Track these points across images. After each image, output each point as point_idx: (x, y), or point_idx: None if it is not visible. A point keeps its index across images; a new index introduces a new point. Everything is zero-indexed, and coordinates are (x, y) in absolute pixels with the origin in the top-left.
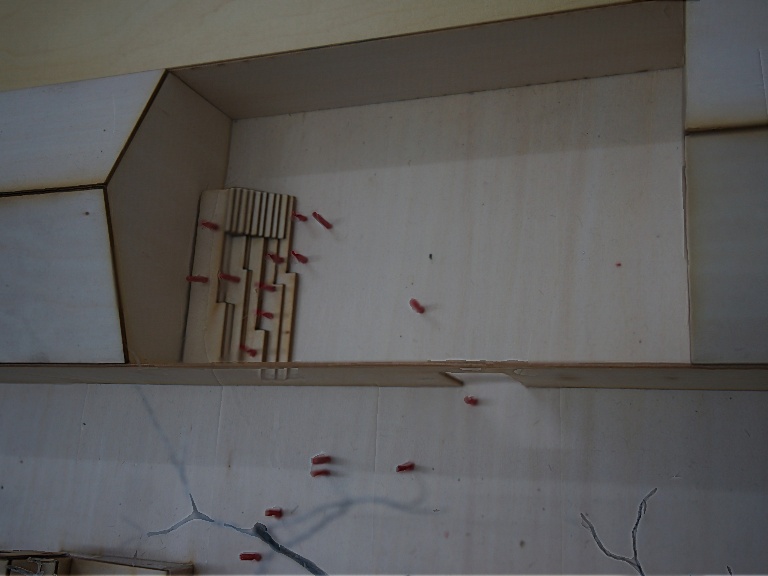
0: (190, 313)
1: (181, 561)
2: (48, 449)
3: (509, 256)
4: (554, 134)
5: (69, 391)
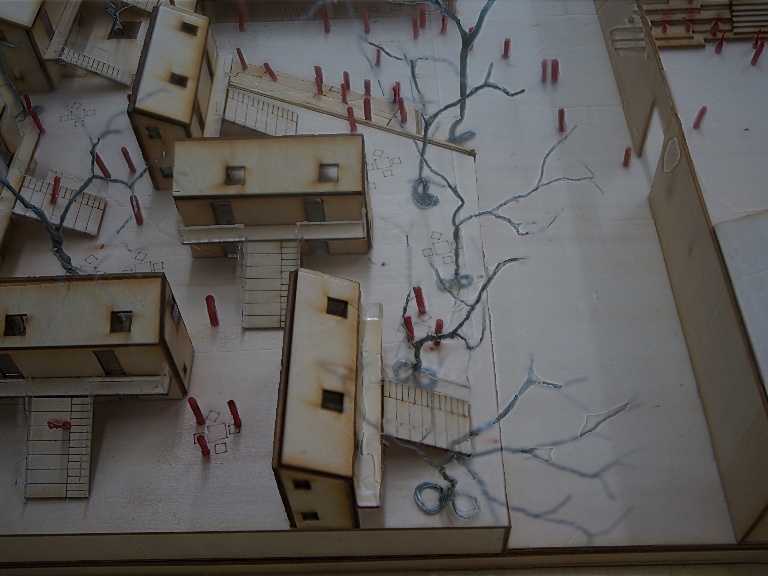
0: None
1: (457, 7)
2: None
3: (764, 179)
4: None
5: None
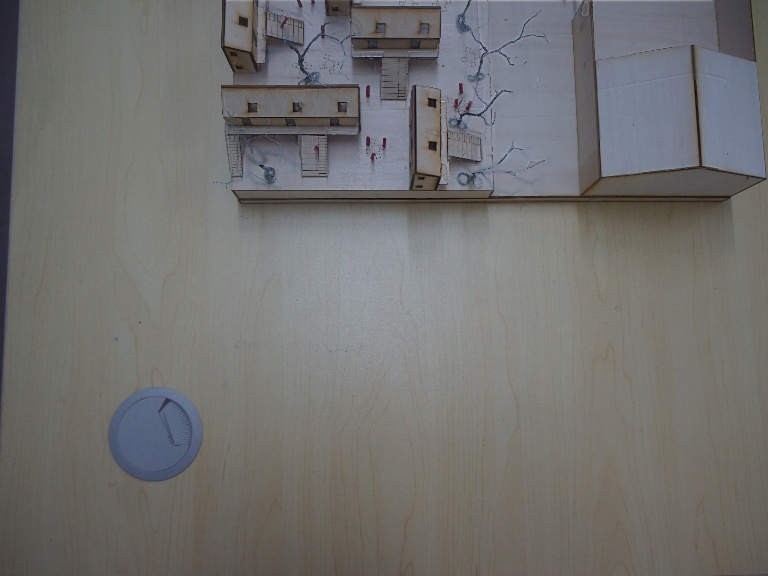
0: None
1: None
2: None
3: (632, 11)
4: (691, 30)
5: None
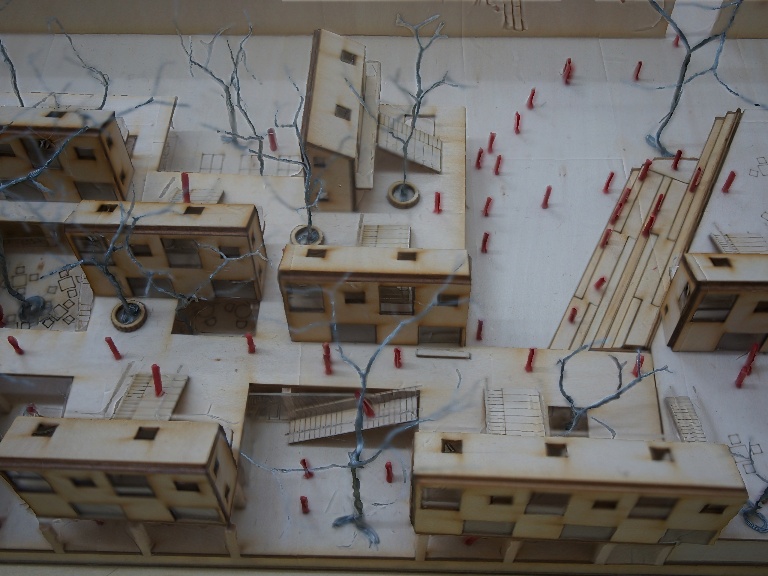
0: None
1: None
2: (290, 75)
3: None
4: None
5: (308, 40)
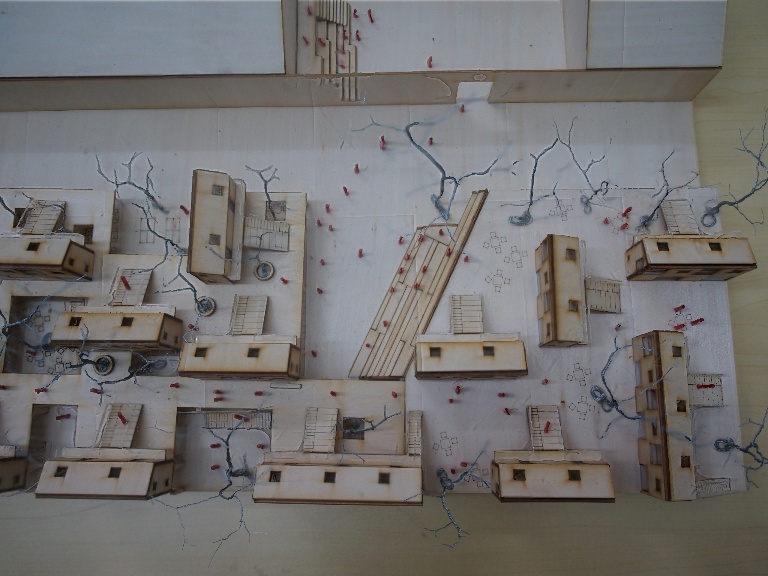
0: (298, 61)
1: None
2: (195, 146)
3: (476, 40)
4: None
5: (206, 112)
